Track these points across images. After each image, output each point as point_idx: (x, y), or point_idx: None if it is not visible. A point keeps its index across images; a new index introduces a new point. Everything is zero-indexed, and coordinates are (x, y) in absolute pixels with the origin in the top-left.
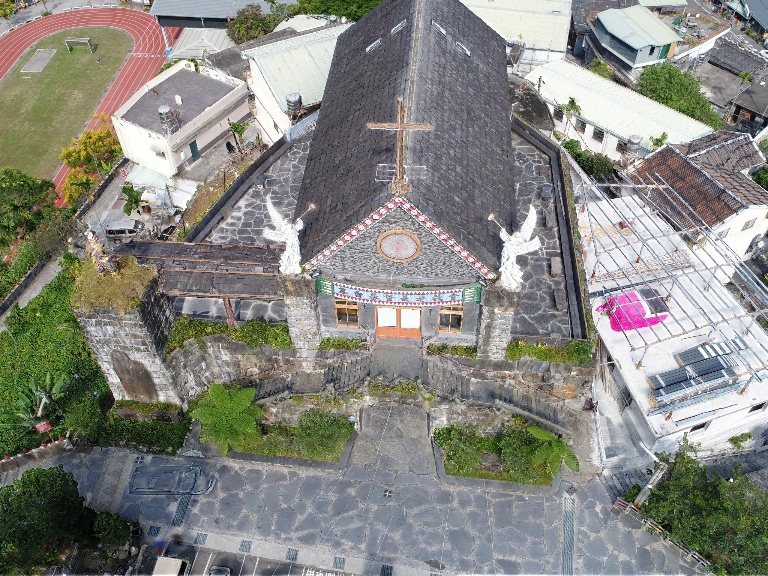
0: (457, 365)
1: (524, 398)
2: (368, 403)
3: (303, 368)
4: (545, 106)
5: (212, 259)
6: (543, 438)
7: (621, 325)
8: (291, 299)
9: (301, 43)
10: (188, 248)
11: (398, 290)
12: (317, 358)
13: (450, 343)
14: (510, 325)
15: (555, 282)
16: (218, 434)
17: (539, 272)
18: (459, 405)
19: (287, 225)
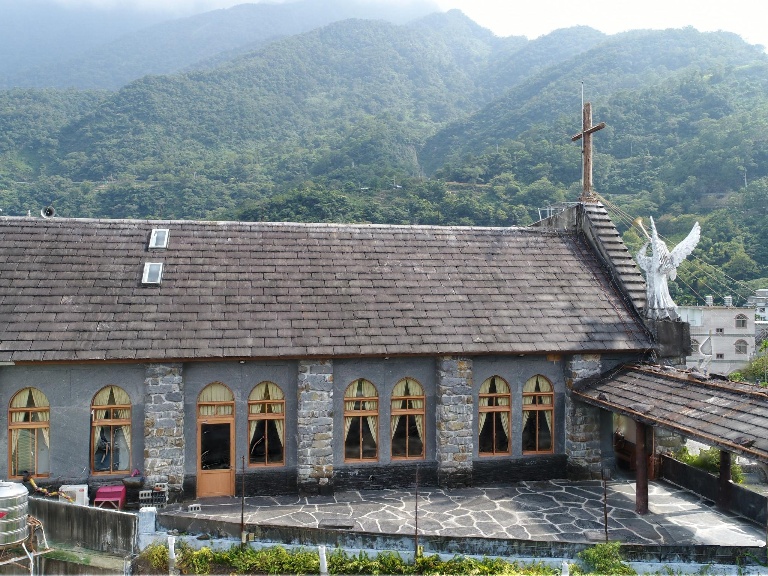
0: None
1: None
2: None
3: None
4: None
5: (698, 390)
6: None
7: None
8: None
9: None
10: (699, 419)
11: None
12: None
13: None
14: None
15: None
16: None
17: None
18: None
19: None
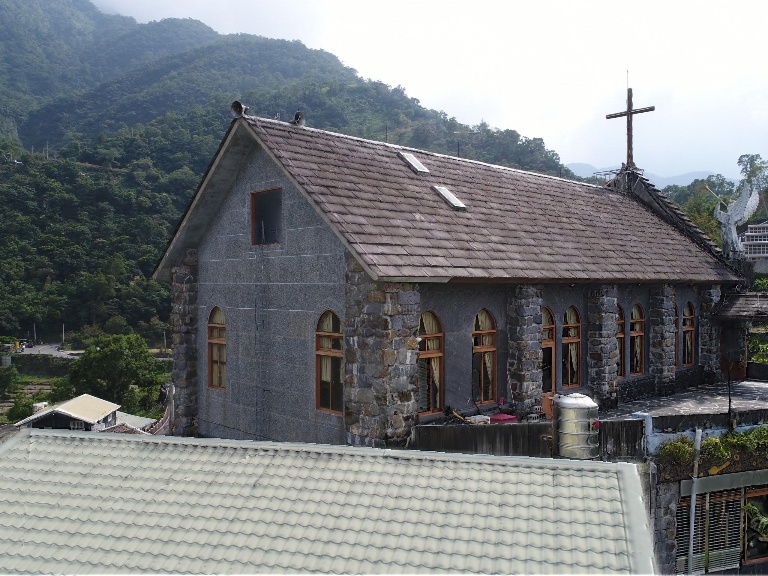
0: None
1: None
2: None
3: None
4: None
5: None
6: None
7: None
8: None
9: (345, 468)
10: None
11: None
12: None
13: None
14: None
15: None
16: None
17: None
18: None
19: None
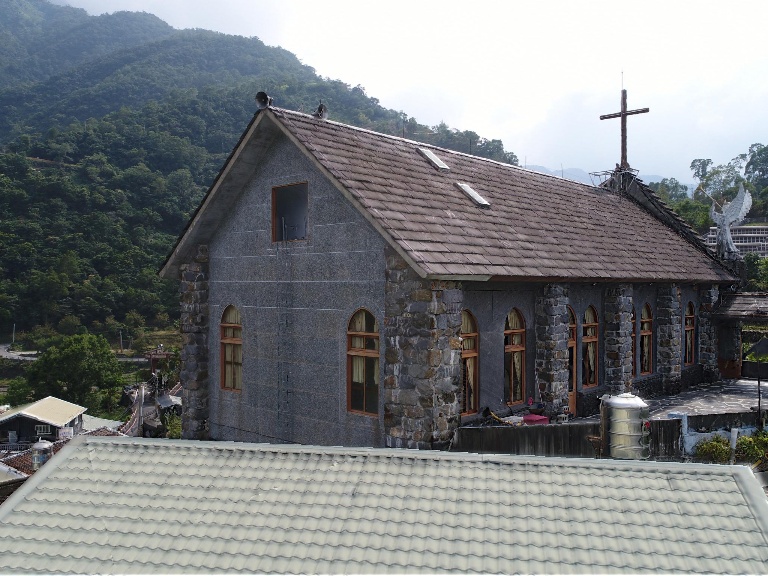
0: None
1: None
2: None
3: None
4: (14, 483)
5: None
6: None
7: None
8: None
9: (446, 474)
10: None
11: None
12: None
13: None
14: None
15: None
16: None
17: None
18: None
19: None
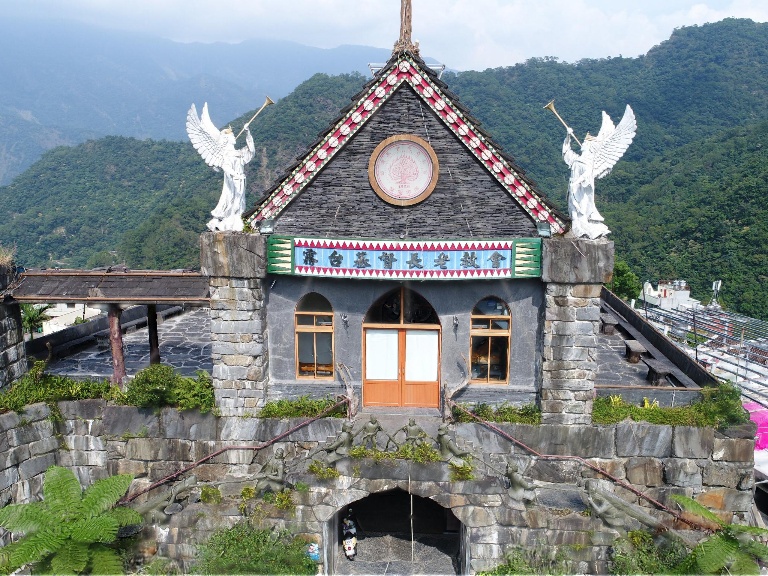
0: (506, 445)
1: (634, 524)
2: (345, 498)
3: (230, 471)
4: None
5: None
6: (708, 516)
7: (759, 436)
8: (221, 288)
9: None
10: None
11: (403, 240)
12: (257, 441)
13: (491, 404)
14: (595, 331)
15: (639, 366)
16: (34, 544)
17: (611, 359)
18: (521, 490)
19: (228, 135)
